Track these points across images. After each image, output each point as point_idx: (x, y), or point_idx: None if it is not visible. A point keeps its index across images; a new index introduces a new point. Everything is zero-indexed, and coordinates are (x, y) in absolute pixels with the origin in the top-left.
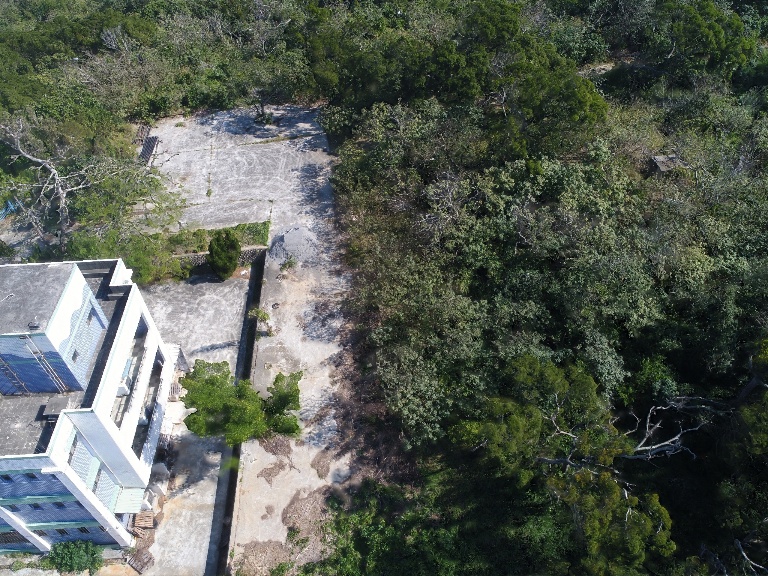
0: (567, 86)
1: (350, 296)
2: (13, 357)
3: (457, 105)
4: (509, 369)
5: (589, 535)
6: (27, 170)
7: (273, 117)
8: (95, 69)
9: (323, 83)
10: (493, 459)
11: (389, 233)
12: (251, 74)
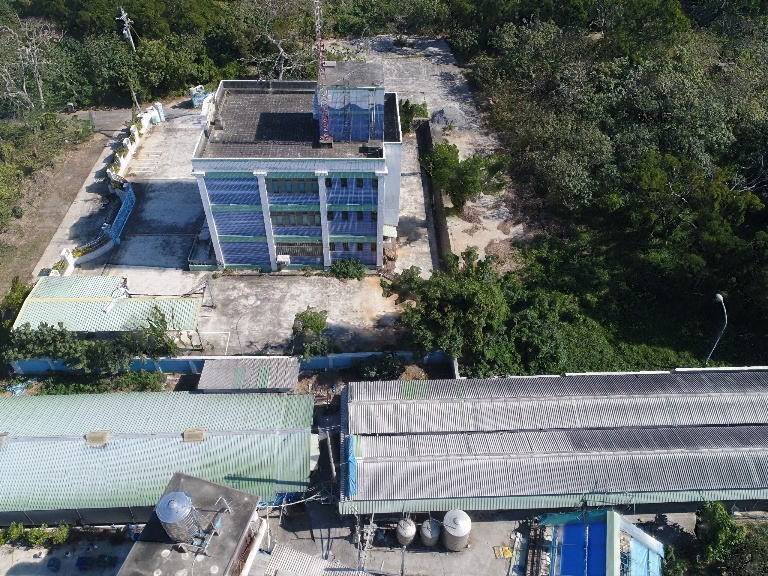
0: (662, 4)
1: (499, 146)
2: (356, 107)
3: (569, 26)
4: (642, 155)
5: (716, 198)
6: (233, 63)
7: (407, 42)
8: (259, 2)
9: (460, 11)
10: (624, 221)
11: (531, 101)
12: (395, 6)
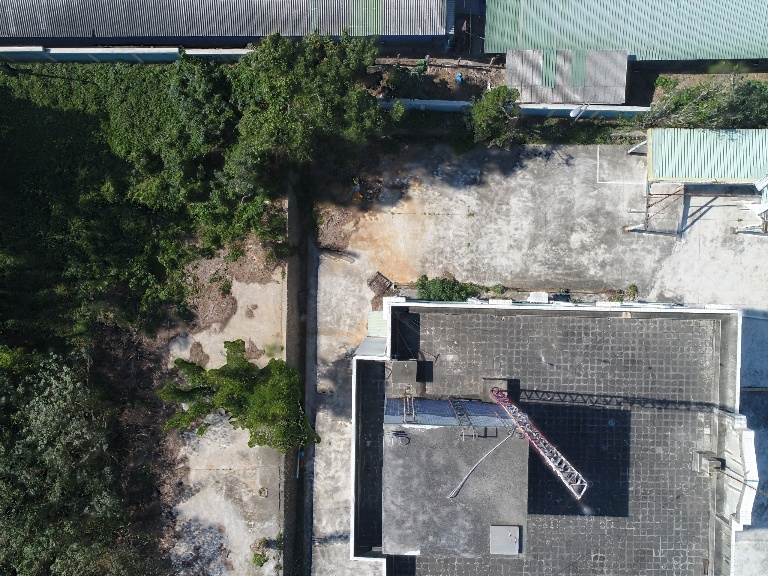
0: None
1: None
2: None
3: None
4: None
5: None
6: None
7: None
8: None
9: None
10: (7, 335)
11: None
12: None
